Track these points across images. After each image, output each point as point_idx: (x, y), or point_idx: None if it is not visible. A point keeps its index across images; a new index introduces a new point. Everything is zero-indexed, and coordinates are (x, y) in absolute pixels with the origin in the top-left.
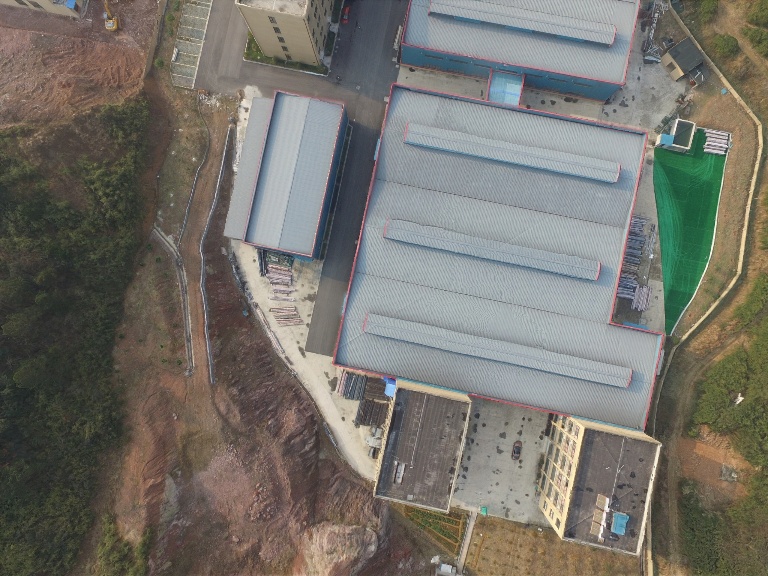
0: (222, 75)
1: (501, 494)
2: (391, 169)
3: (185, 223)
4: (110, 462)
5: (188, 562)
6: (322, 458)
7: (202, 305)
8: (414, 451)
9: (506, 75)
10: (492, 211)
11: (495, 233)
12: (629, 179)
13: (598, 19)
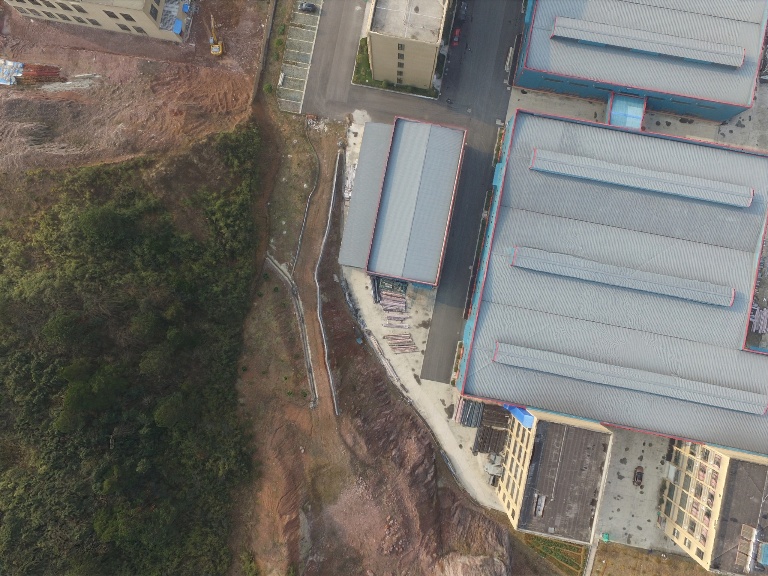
0: (330, 99)
1: (623, 520)
2: (516, 195)
3: (298, 251)
4: (242, 498)
5: None
6: (441, 486)
7: (321, 335)
8: (555, 483)
9: (627, 98)
10: (619, 237)
11: (624, 259)
12: (760, 203)
13: (723, 41)
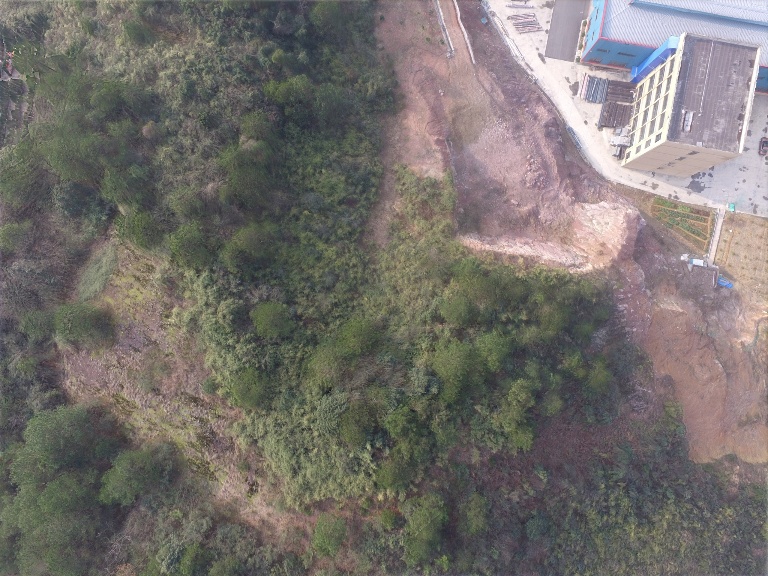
0: None
1: (748, 191)
2: None
3: None
4: (387, 126)
5: (476, 216)
6: (567, 160)
7: None
8: (703, 98)
9: None
10: None
11: None
12: None
13: None
